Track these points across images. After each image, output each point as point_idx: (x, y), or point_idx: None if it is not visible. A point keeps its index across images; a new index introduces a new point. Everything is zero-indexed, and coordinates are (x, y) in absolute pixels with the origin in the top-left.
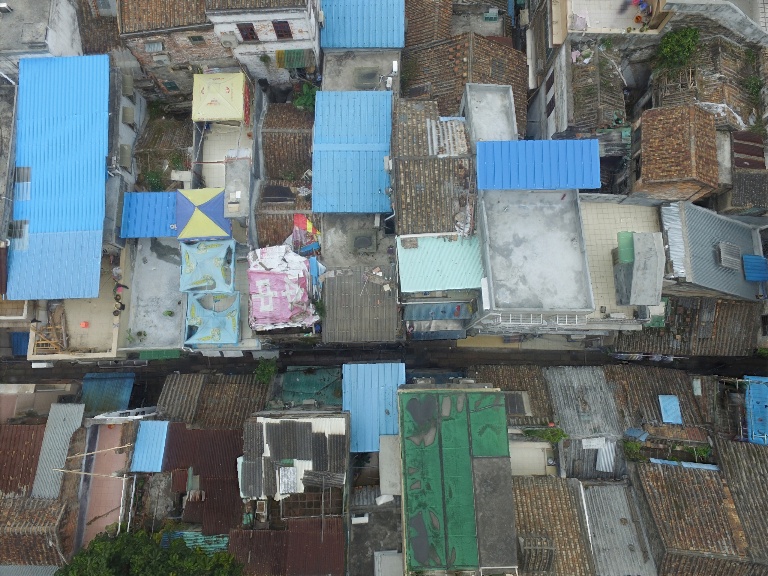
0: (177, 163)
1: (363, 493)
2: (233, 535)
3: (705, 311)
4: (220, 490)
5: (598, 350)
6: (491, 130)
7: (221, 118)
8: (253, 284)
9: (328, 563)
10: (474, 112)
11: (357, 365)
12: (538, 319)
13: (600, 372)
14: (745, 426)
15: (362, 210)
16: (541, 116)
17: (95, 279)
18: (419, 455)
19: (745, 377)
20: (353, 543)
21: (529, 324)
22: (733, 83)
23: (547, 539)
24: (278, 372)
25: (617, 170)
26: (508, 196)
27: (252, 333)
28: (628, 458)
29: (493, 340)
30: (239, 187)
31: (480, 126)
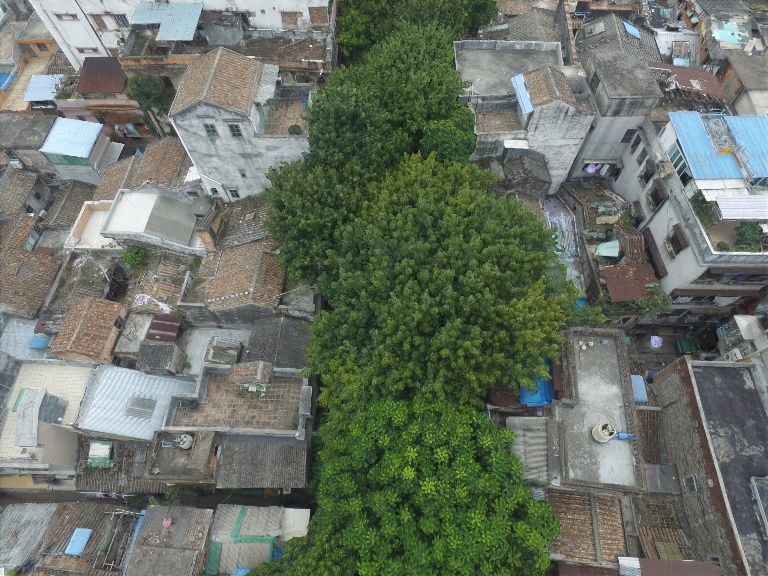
0: None
1: None
2: None
3: (138, 453)
4: None
5: None
6: None
7: None
8: None
9: None
10: None
11: None
12: None
13: (53, 508)
14: None
15: None
16: None
17: None
18: None
19: (142, 511)
20: None
21: None
22: (168, 281)
23: None
24: None
25: None
26: None
27: None
28: None
29: (27, 482)
30: None
31: None
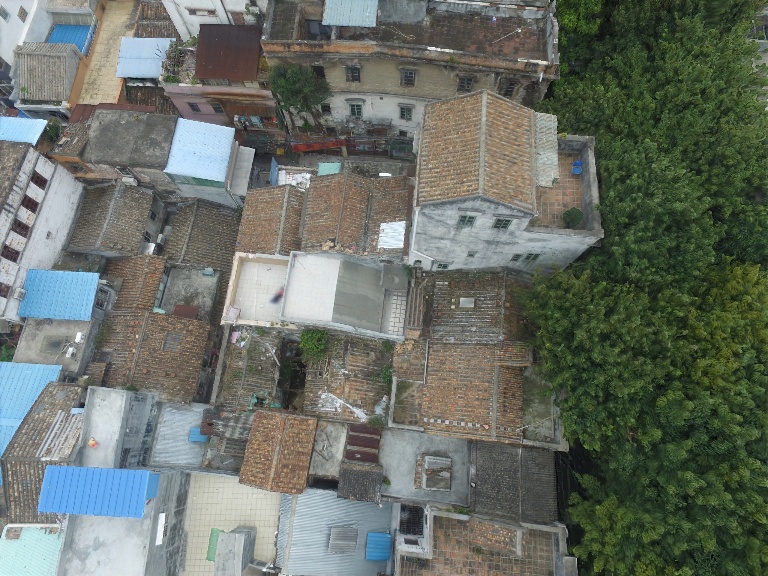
0: None
1: None
2: None
3: None
4: None
5: None
6: (105, 429)
7: None
8: None
9: None
10: (95, 410)
11: None
12: None
13: None
14: None
15: None
16: None
17: None
18: None
19: None
20: None
21: None
22: (359, 377)
23: None
24: None
25: None
26: None
27: None
28: None
29: None
30: None
31: (97, 424)
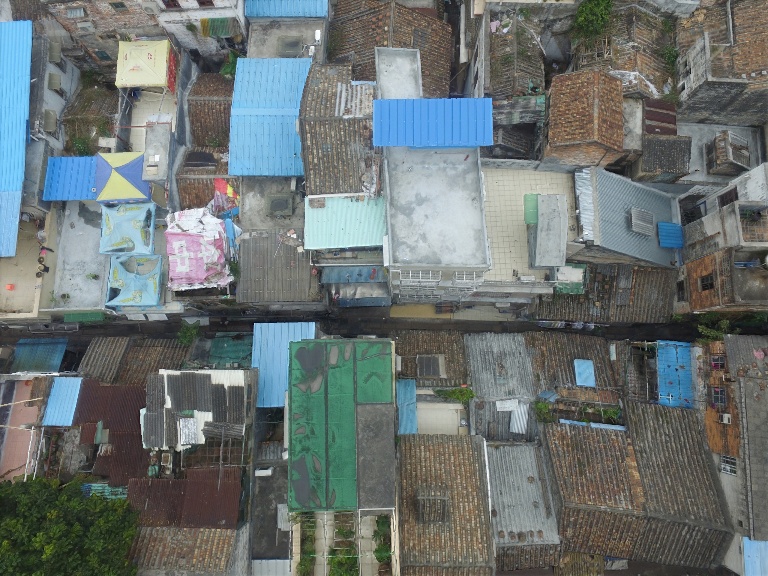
0: (103, 129)
1: (270, 448)
2: (132, 483)
3: (622, 278)
4: (128, 443)
5: (528, 321)
6: (399, 93)
7: (144, 84)
8: (170, 245)
9: (223, 510)
10: (383, 76)
11: (268, 324)
12: (437, 276)
13: (521, 338)
14: (656, 389)
15: (277, 173)
16: (471, 89)
17: (12, 238)
18: (305, 401)
19: (658, 341)
20: (258, 496)
21: (428, 281)
22: (647, 52)
23: (441, 490)
24: (207, 338)
25: (535, 138)
26: (412, 157)
27: (172, 295)
28: (539, 419)
29: (426, 311)
30: (158, 151)
31: (389, 89)
